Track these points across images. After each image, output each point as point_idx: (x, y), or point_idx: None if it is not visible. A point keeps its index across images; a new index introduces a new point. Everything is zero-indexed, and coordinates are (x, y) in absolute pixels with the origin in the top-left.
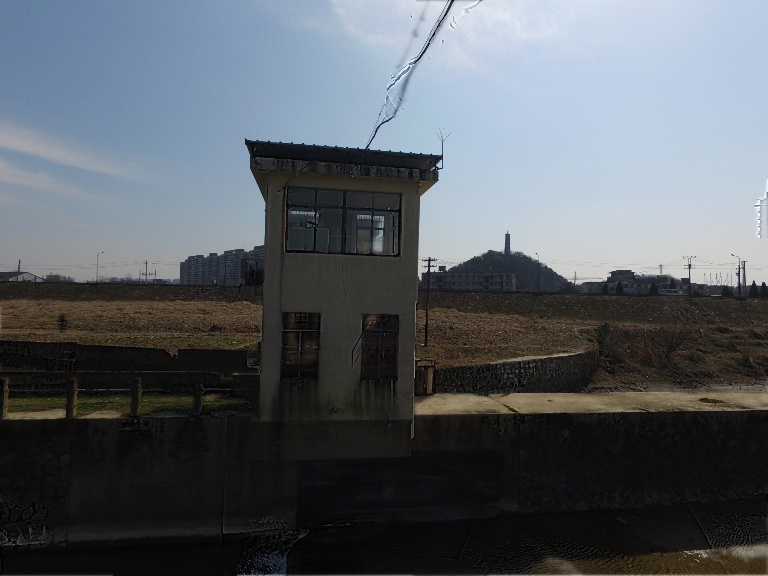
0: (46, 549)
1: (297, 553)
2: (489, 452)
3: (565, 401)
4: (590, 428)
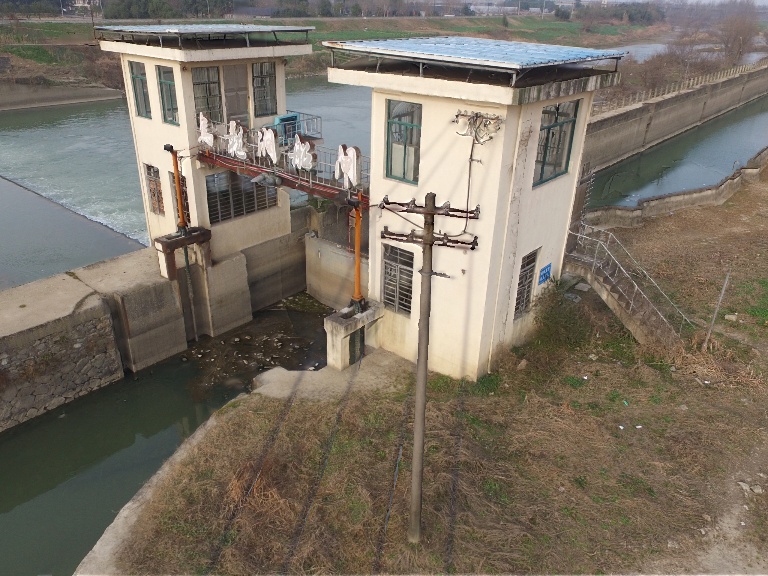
0: None
1: None
2: None
3: (3, 311)
4: None
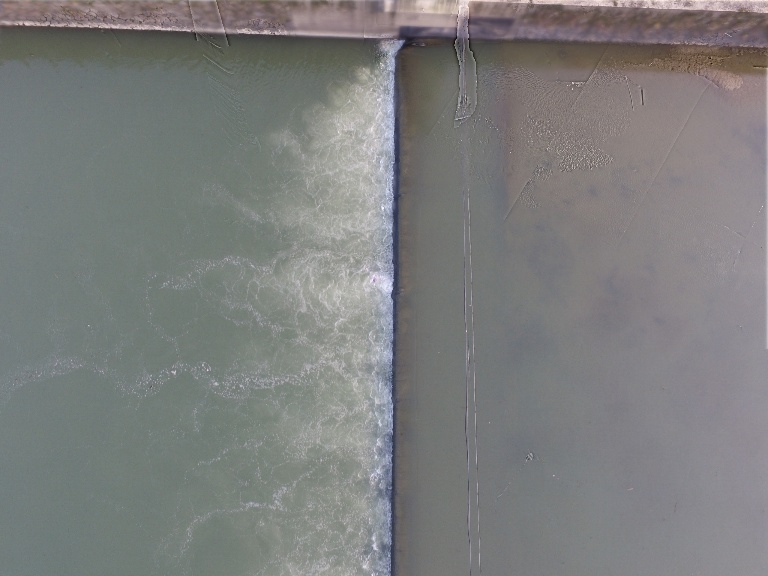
0: (288, 37)
1: (400, 61)
2: (506, 19)
3: None
4: (572, 13)
